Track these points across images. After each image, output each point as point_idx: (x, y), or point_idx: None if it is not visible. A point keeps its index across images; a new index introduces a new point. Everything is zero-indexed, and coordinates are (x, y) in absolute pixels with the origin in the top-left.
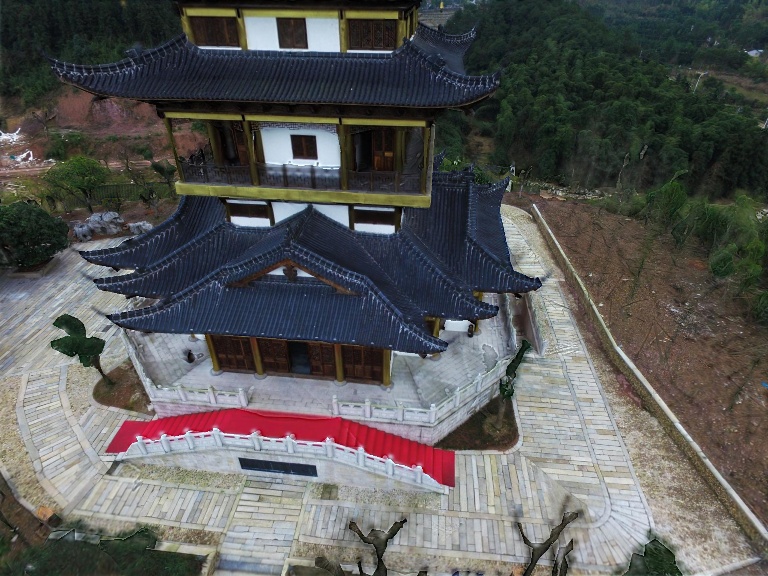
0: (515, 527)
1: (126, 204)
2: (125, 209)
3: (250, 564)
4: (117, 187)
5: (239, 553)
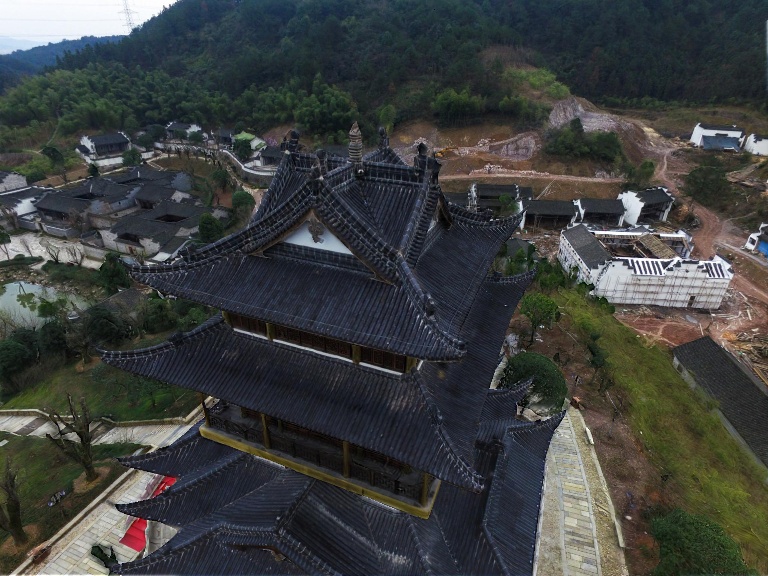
0: (64, 571)
1: (574, 356)
2: (564, 357)
3: (172, 436)
4: (734, 367)
5: (180, 432)
